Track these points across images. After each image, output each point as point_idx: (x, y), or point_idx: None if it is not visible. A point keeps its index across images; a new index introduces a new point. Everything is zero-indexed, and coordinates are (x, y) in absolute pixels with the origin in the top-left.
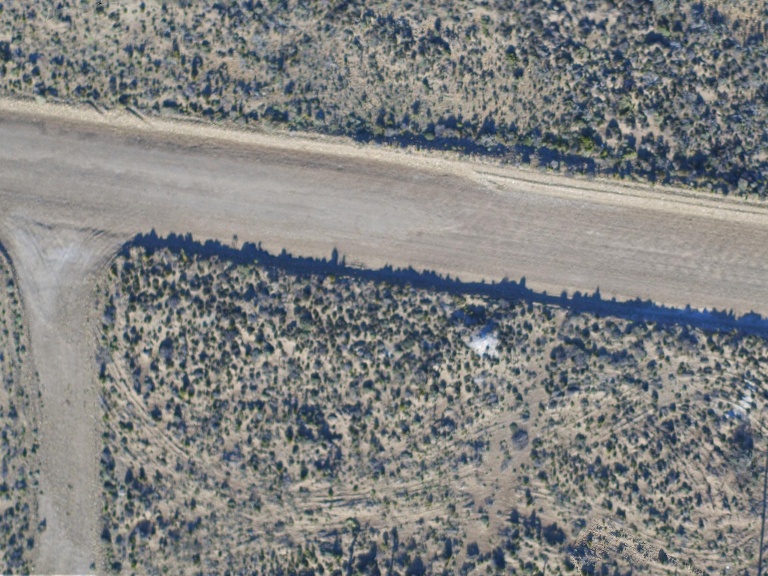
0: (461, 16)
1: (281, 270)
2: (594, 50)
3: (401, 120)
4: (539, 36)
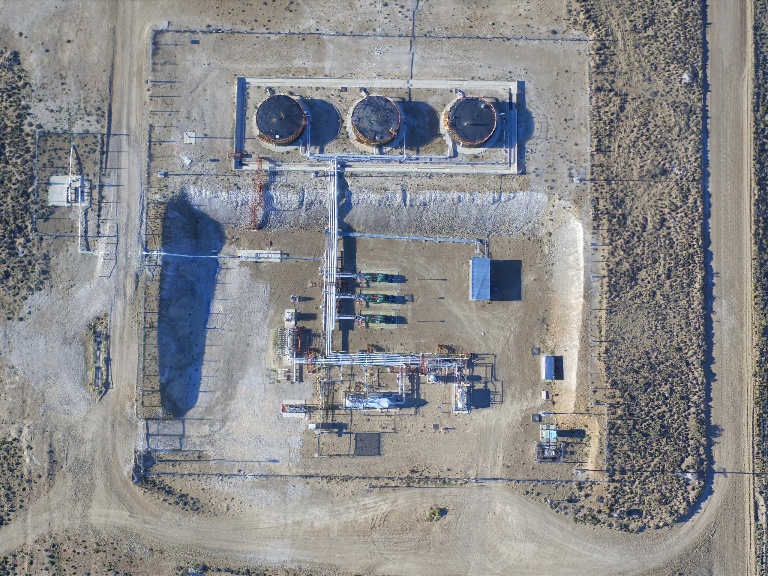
0: None
1: (702, 5)
2: None
3: (764, 42)
4: None
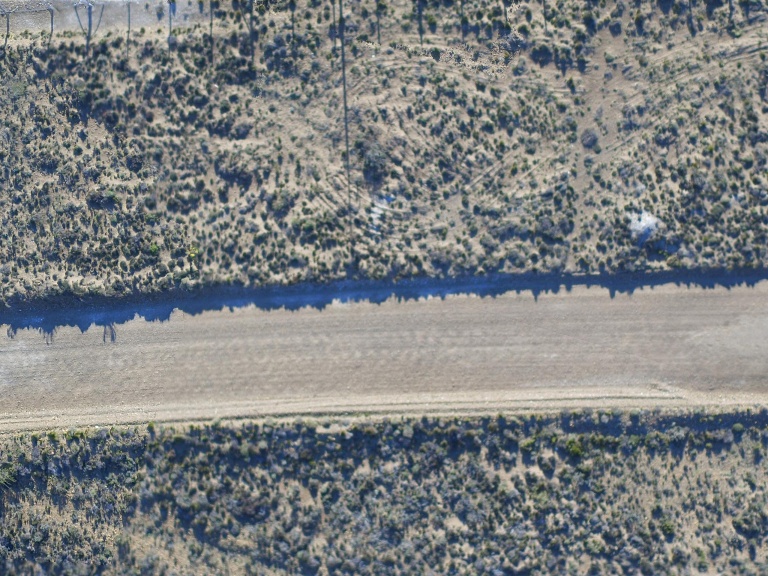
0: (730, 567)
1: None
2: (582, 552)
3: None
4: (644, 558)
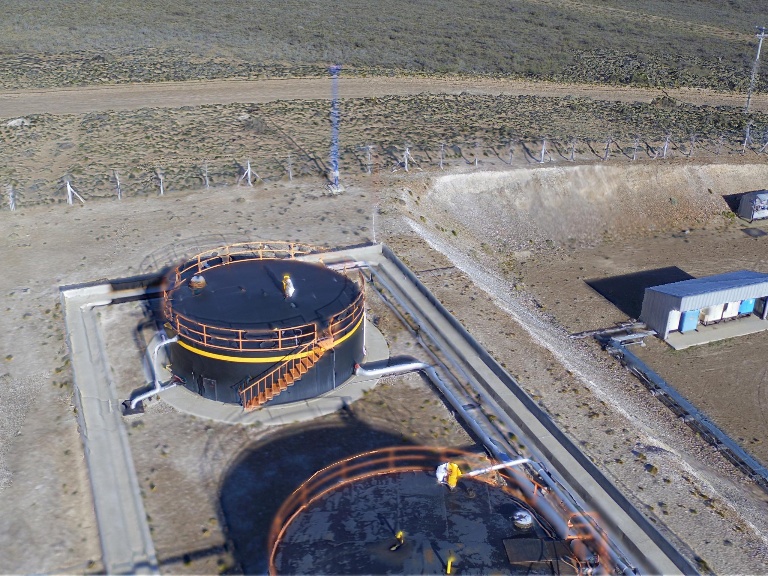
0: None
1: None
2: None
3: None
4: None
